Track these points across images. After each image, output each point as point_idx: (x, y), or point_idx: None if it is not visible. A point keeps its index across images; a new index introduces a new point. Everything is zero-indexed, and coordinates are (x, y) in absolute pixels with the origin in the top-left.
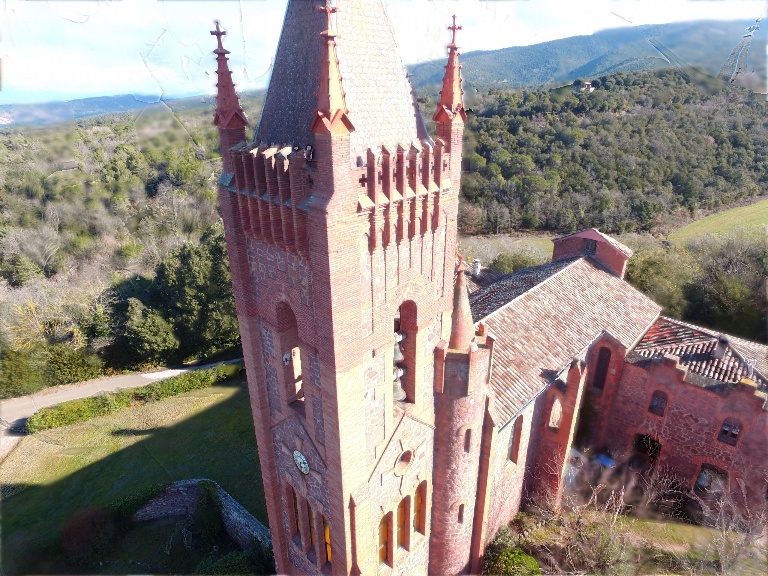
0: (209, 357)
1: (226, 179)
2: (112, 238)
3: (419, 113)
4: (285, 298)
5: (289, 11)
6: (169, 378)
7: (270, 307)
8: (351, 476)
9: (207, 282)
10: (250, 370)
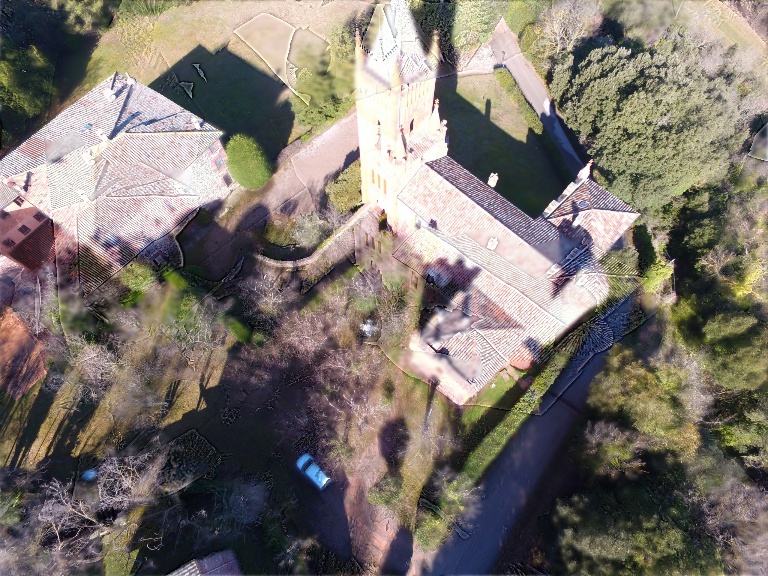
0: None
1: None
2: None
3: None
4: None
5: None
6: None
7: None
8: None
9: None
10: None
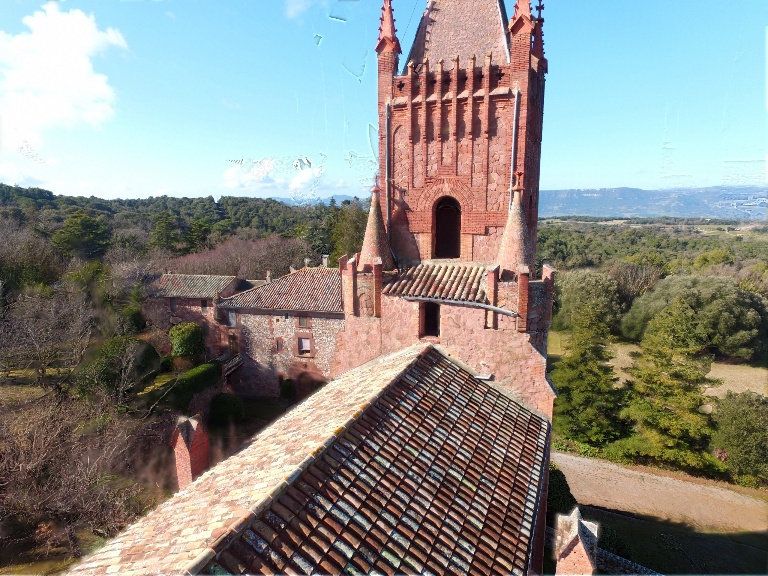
0: None
1: None
2: None
3: (412, 48)
4: None
5: None
6: None
7: None
8: None
9: None
10: None
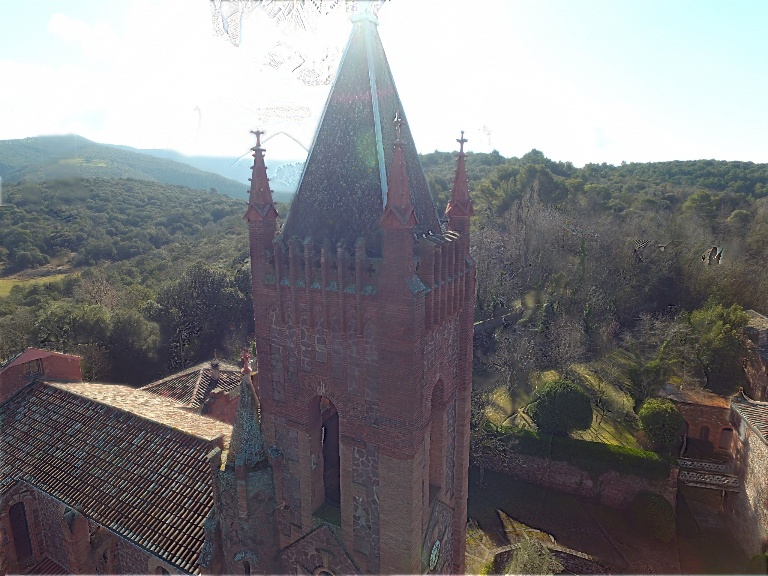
0: None
1: (418, 284)
2: None
3: None
4: (439, 375)
5: (381, 115)
6: None
7: (427, 405)
8: None
9: None
10: (417, 521)
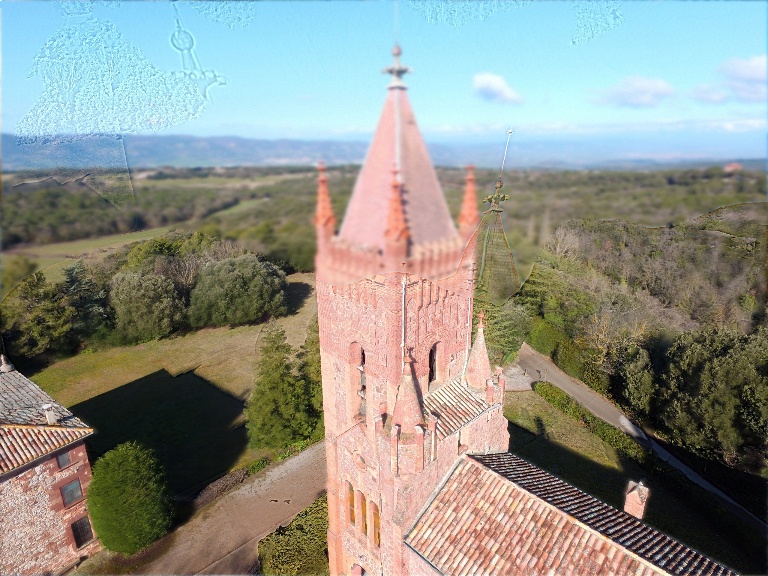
0: (675, 447)
1: None
2: (760, 309)
3: None
4: None
5: None
6: (611, 425)
7: None
8: (328, 419)
9: (689, 370)
10: None
